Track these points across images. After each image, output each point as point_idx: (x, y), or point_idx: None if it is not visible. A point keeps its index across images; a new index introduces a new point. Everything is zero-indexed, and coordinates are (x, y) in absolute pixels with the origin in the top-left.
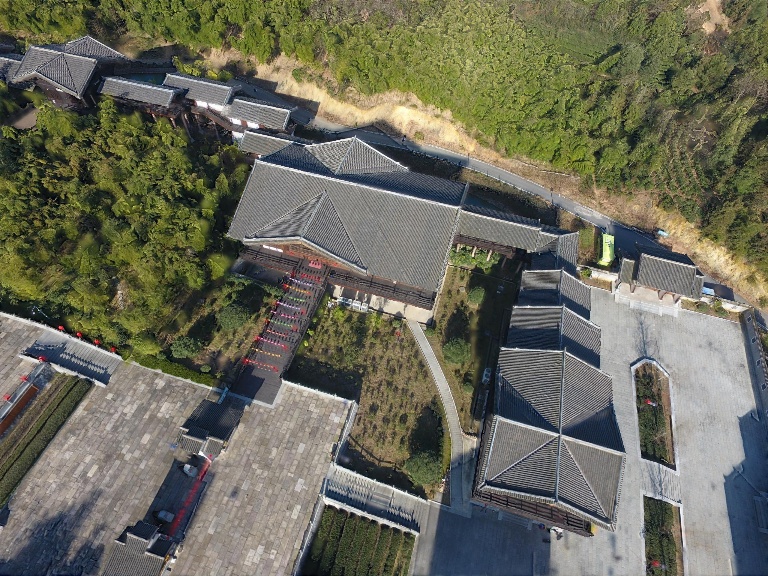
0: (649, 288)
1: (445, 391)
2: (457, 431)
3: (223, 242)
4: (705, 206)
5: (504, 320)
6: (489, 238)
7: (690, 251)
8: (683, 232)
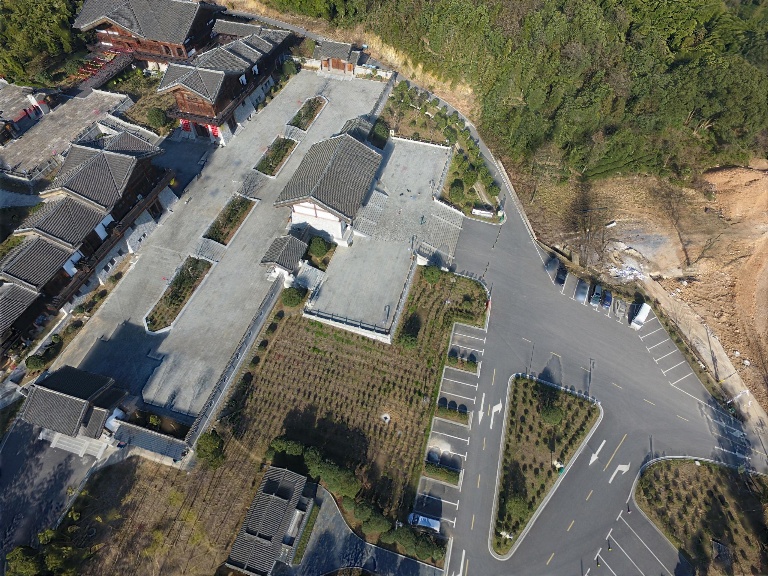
0: (340, 69)
1: None
2: None
3: (78, 41)
4: None
5: None
6: (232, 33)
7: (380, 55)
8: (376, 44)
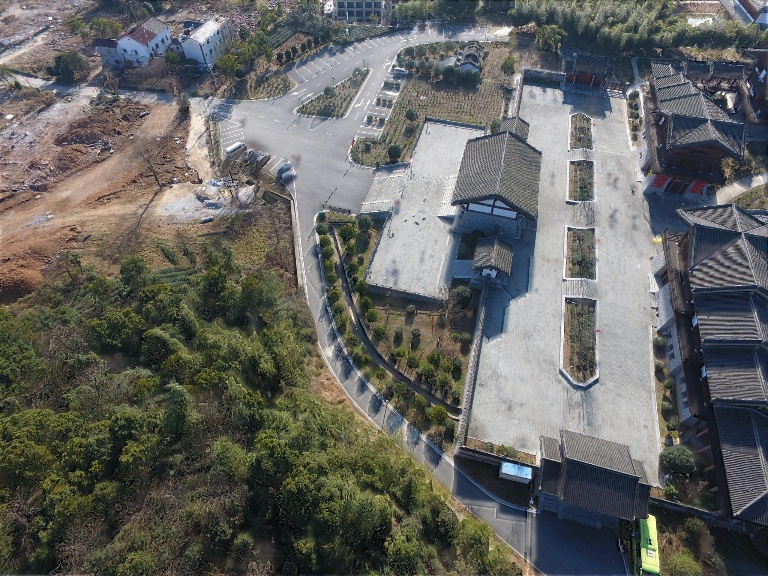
0: None
1: None
2: None
3: None
4: None
5: None
6: None
7: None
8: None
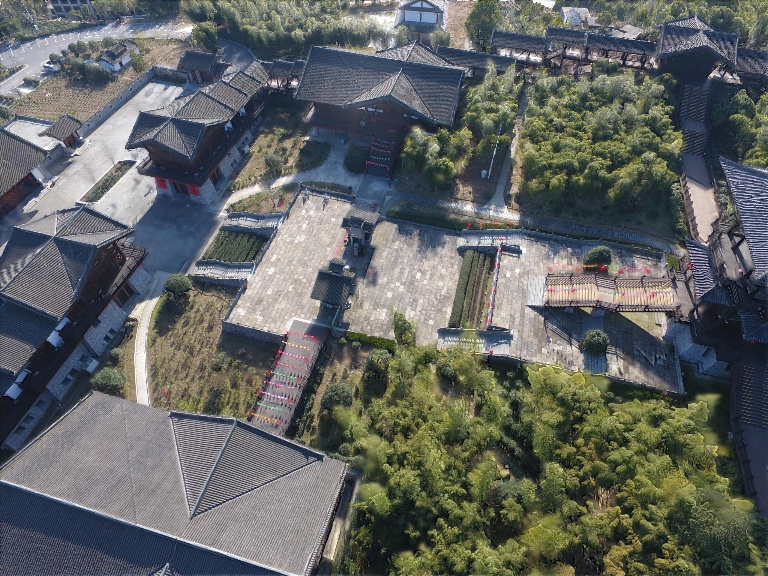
0: None
1: (140, 353)
2: (143, 321)
3: None
4: None
5: None
6: None
7: None
8: None
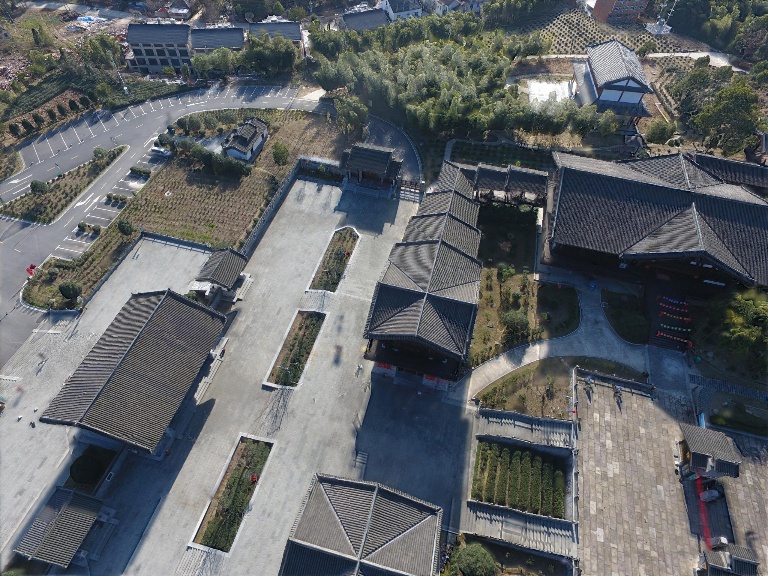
0: None
1: None
2: None
3: None
4: None
5: None
6: None
7: None
8: None
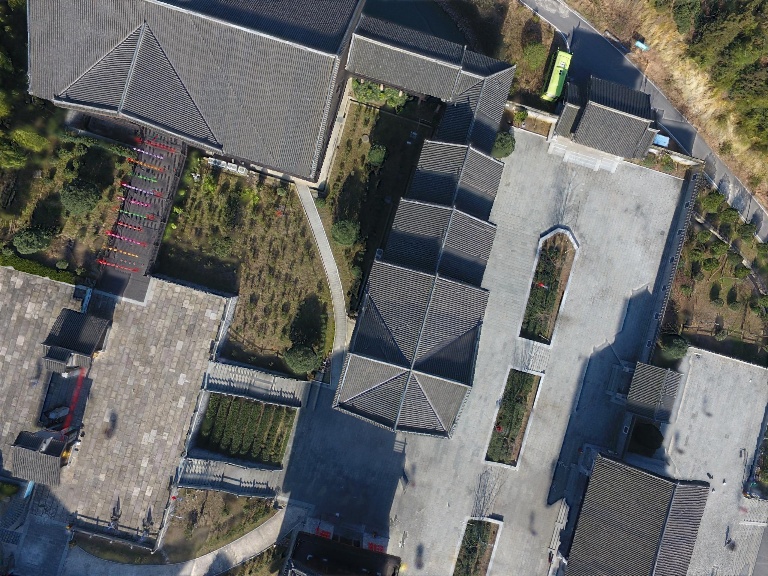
0: None
1: (333, 273)
2: (342, 315)
3: None
4: (710, 6)
5: (410, 181)
6: (392, 80)
7: (667, 73)
8: (667, 45)
